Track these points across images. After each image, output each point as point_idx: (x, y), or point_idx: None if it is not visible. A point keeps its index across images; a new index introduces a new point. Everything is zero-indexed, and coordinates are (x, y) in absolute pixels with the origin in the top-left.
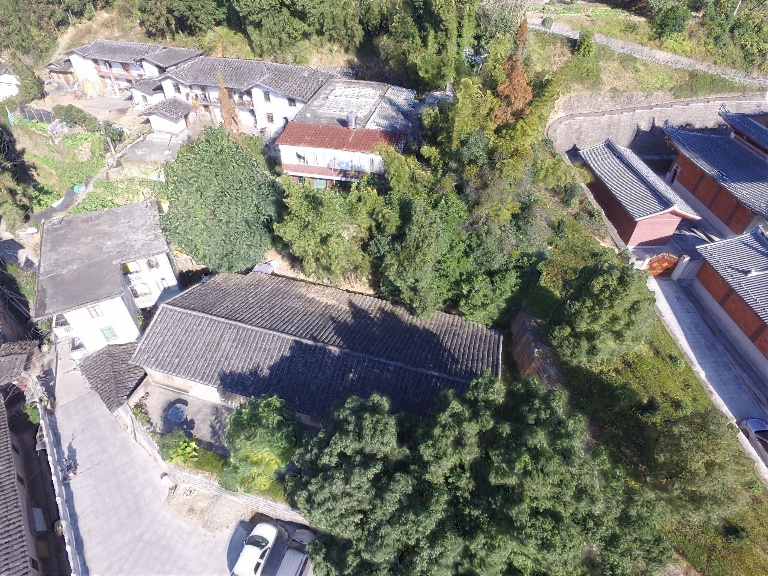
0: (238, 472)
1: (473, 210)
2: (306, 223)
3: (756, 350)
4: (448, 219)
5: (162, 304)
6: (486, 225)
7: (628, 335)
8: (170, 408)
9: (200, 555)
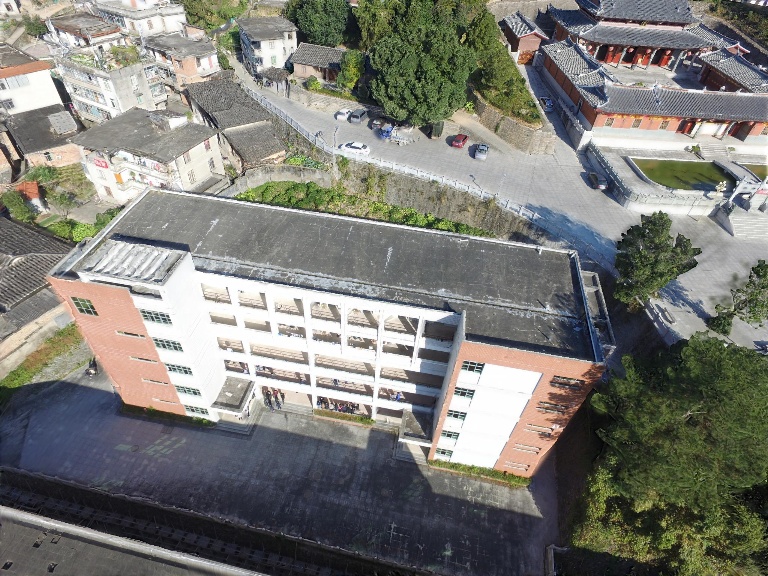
0: (344, 73)
1: (436, 4)
2: (366, 8)
3: (555, 82)
4: (426, 8)
5: (301, 42)
6: (440, 8)
7: (486, 38)
8: (305, 83)
9: (324, 115)
